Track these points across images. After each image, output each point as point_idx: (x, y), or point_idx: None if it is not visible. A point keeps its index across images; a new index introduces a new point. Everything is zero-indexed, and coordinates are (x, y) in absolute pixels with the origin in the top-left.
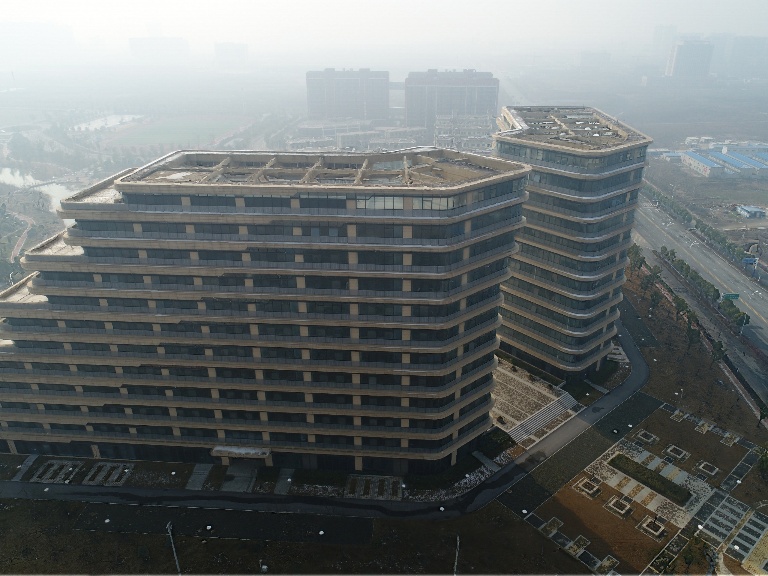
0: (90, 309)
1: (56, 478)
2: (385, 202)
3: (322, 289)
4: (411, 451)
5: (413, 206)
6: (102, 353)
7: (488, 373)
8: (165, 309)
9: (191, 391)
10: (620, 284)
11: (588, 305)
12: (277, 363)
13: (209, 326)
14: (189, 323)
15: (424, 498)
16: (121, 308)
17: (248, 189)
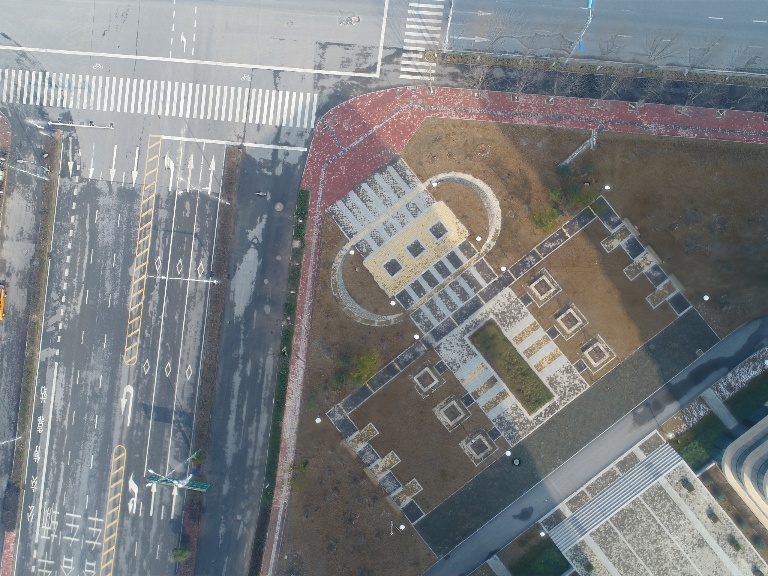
0: None
1: None
2: None
3: None
4: None
5: None
6: None
7: None
8: None
9: None
10: None
11: None
12: None
13: None
14: None
15: None
16: None
17: None
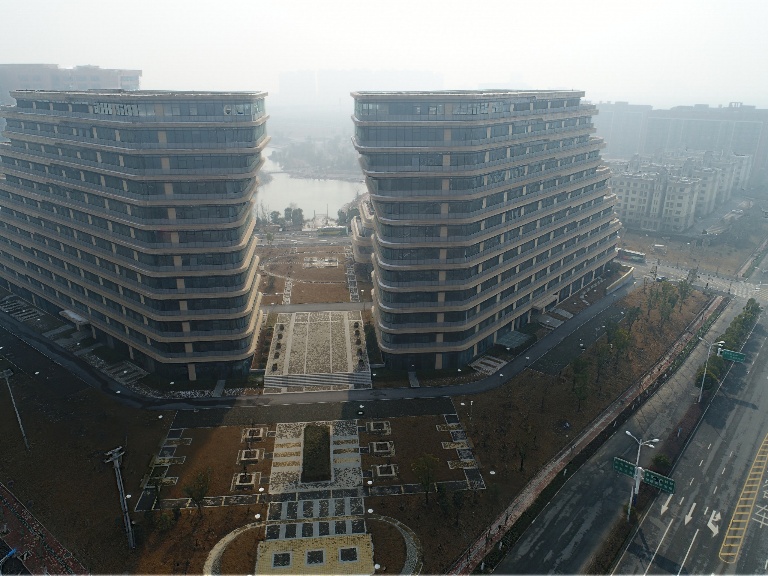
0: (17, 186)
1: (6, 308)
2: (105, 108)
3: (91, 183)
4: (152, 350)
5: (118, 112)
6: (25, 221)
7: (223, 299)
8: (39, 190)
9: (57, 261)
10: (451, 267)
11: (398, 278)
12: (83, 245)
13: (56, 207)
14: (49, 204)
15: (138, 390)
16: (26, 187)
17: (48, 95)
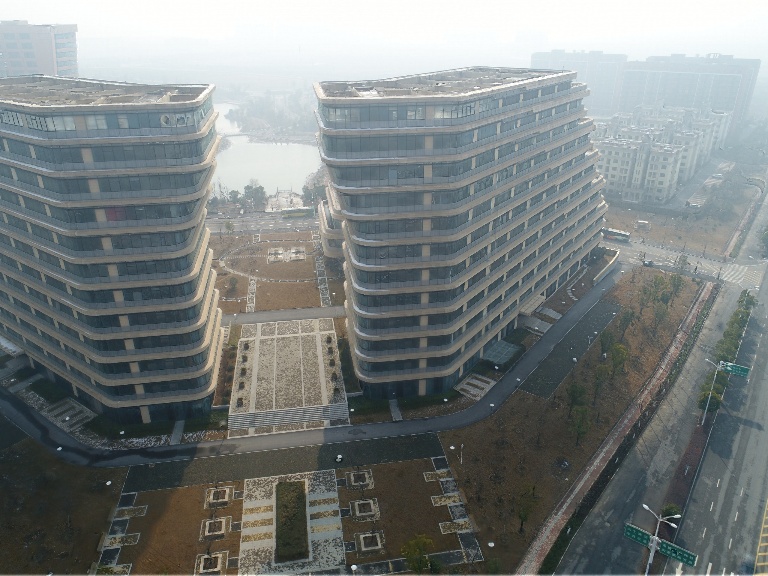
0: None
1: None
2: (14, 118)
3: (8, 202)
4: (98, 391)
5: None
6: None
7: (176, 335)
8: None
9: None
10: (435, 289)
11: (375, 302)
12: (8, 269)
13: None
14: None
15: (84, 439)
16: None
17: None
